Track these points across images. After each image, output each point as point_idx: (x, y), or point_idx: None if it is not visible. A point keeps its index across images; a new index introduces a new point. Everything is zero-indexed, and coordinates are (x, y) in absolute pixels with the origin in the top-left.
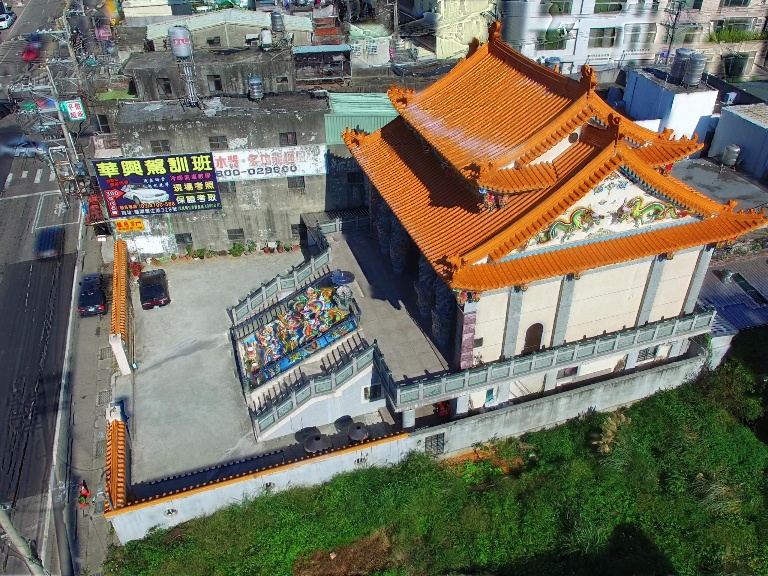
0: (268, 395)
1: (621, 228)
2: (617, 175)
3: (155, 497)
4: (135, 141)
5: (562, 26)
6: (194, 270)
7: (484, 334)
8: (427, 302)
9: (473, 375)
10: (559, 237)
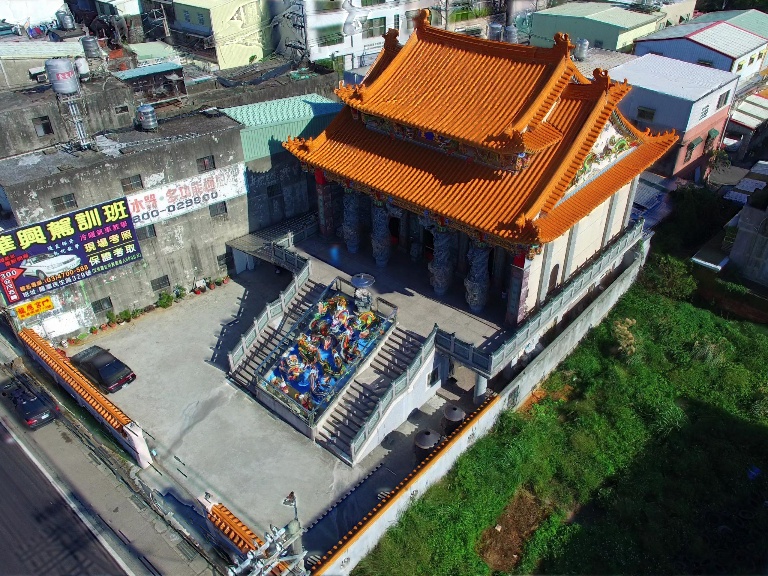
0: (334, 420)
1: (603, 165)
2: None
3: (329, 554)
4: (32, 203)
5: (356, 19)
6: (130, 336)
7: (529, 285)
8: (445, 279)
9: (533, 324)
10: None
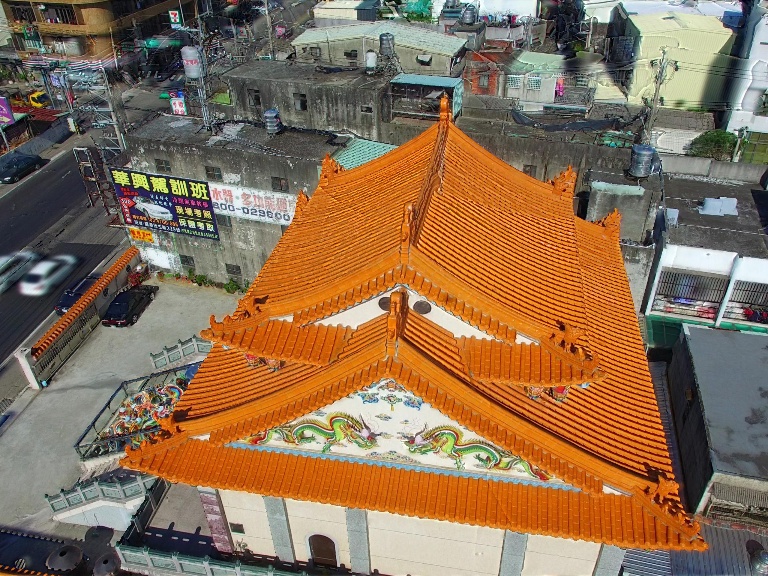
0: (96, 471)
1: (431, 460)
2: (399, 387)
3: None
4: (141, 156)
5: None
6: (183, 296)
7: (243, 521)
8: None
9: (217, 567)
10: (321, 442)
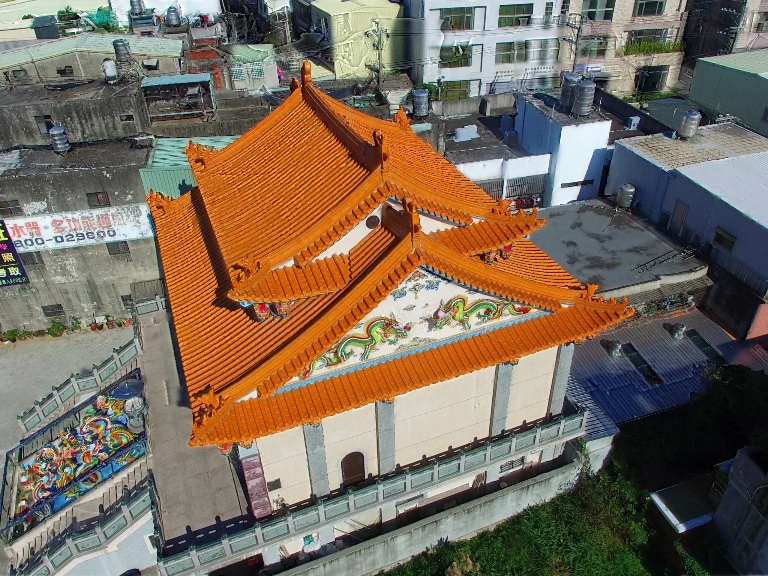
0: (33, 547)
1: (444, 334)
2: (422, 274)
3: None
4: None
5: (457, 44)
6: None
7: (280, 474)
8: None
9: (268, 529)
10: (357, 354)
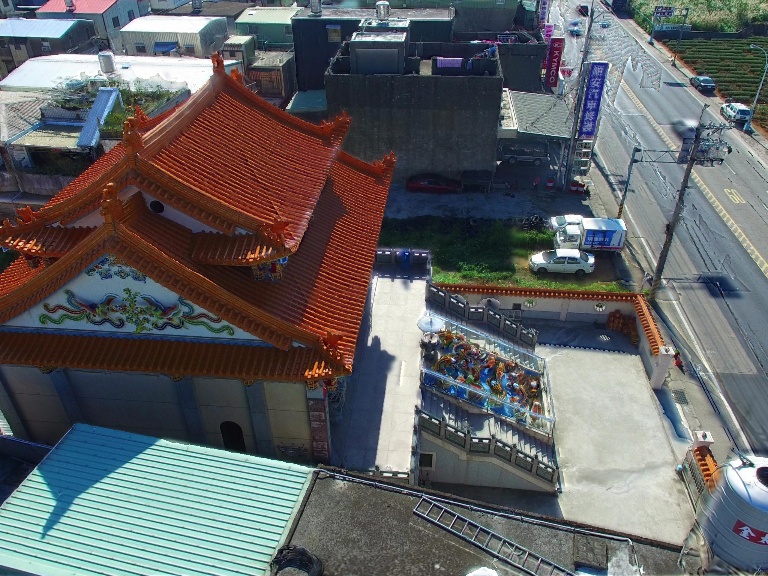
0: None
1: None
2: None
3: (612, 297)
4: None
5: None
6: None
7: None
8: None
9: None
10: None
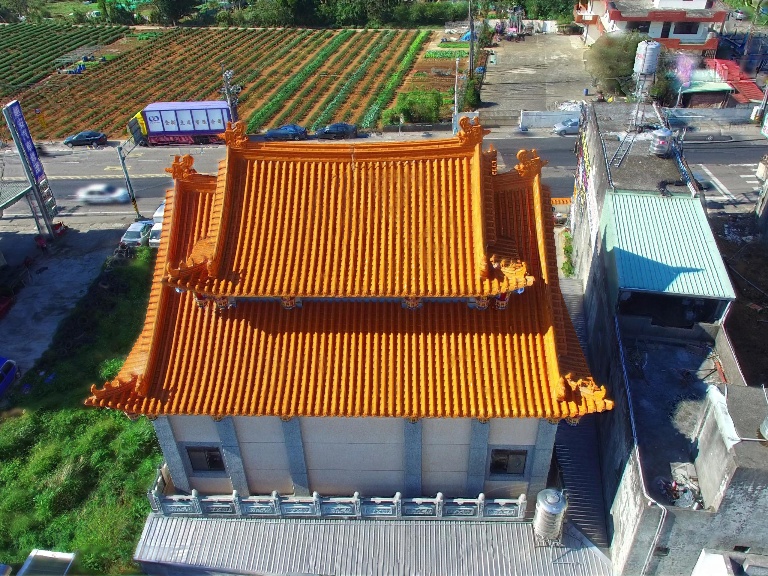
0: None
1: None
2: None
3: None
4: None
5: None
6: None
7: None
8: None
9: None
10: None
